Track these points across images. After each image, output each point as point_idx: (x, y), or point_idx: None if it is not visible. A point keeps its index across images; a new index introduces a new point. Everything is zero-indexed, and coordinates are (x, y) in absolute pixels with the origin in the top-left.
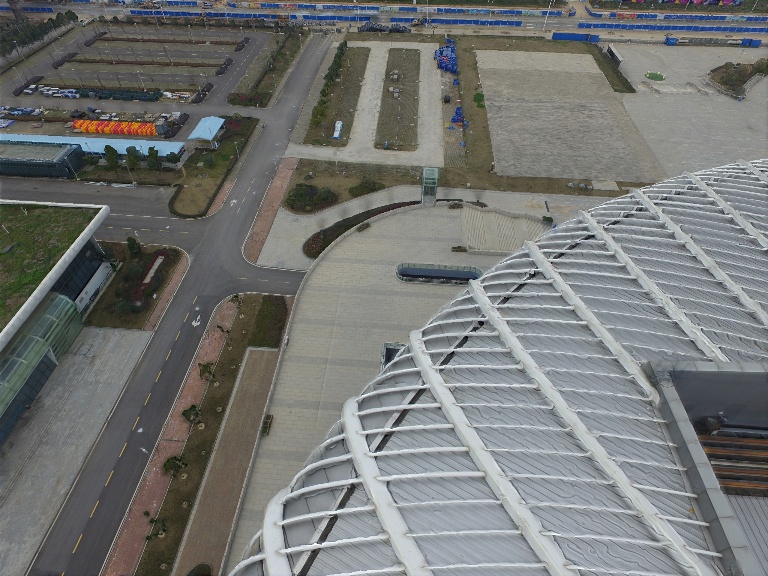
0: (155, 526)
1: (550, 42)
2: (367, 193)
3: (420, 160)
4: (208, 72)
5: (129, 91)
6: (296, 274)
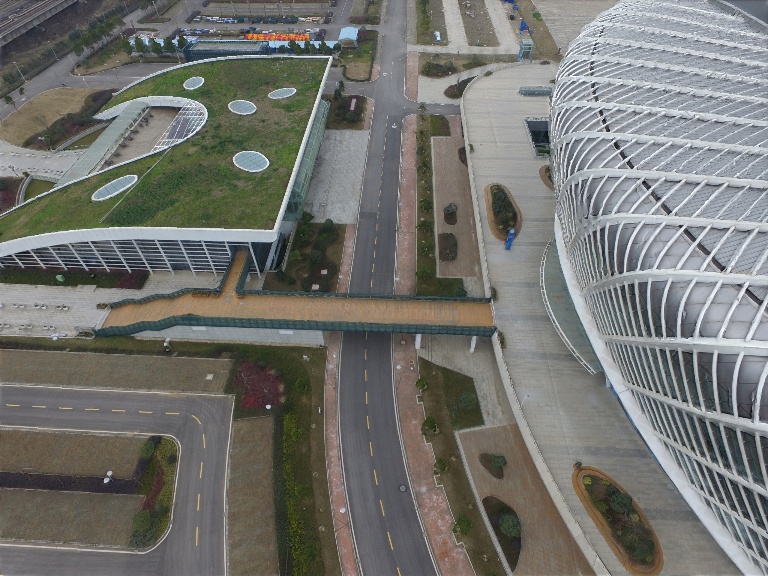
0: (417, 197)
1: None
2: (476, 67)
3: (505, 51)
4: (324, 6)
5: (273, 17)
6: (445, 106)
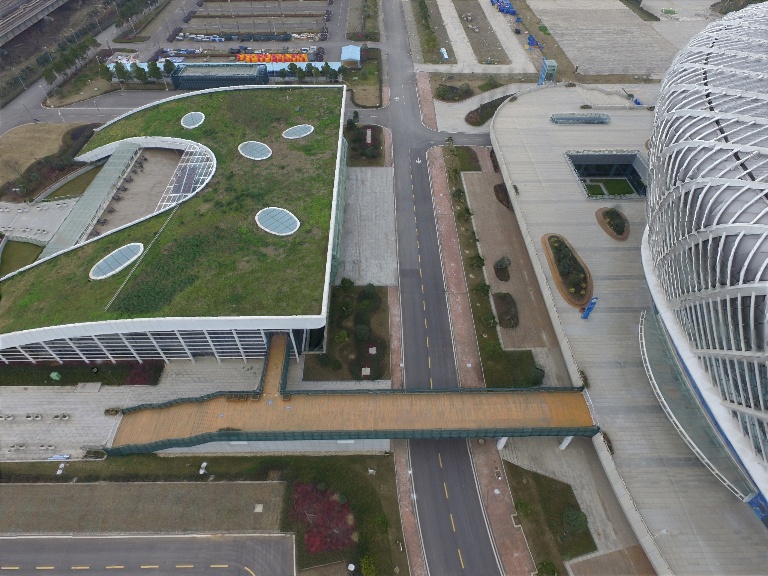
0: (461, 248)
1: None
2: (492, 89)
3: (518, 69)
4: None
5: (263, 35)
6: (469, 135)
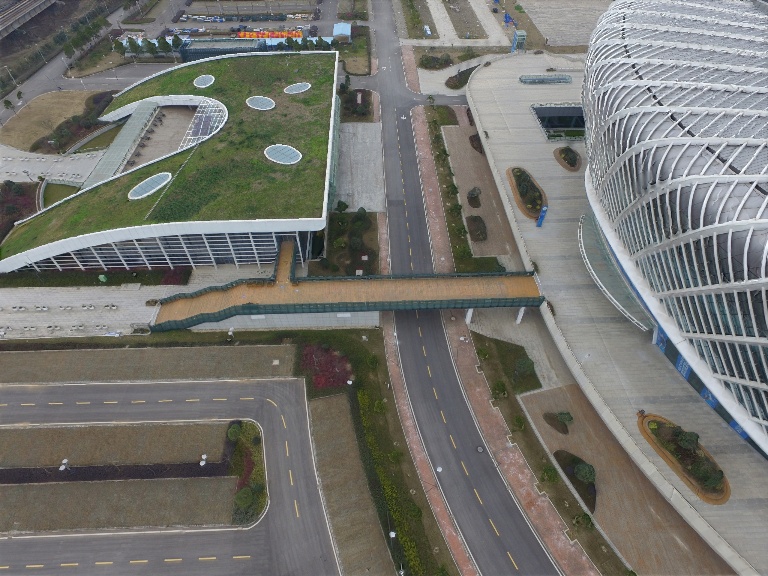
0: (440, 184)
1: None
2: (470, 59)
3: (494, 43)
4: None
5: (261, 15)
6: (448, 97)
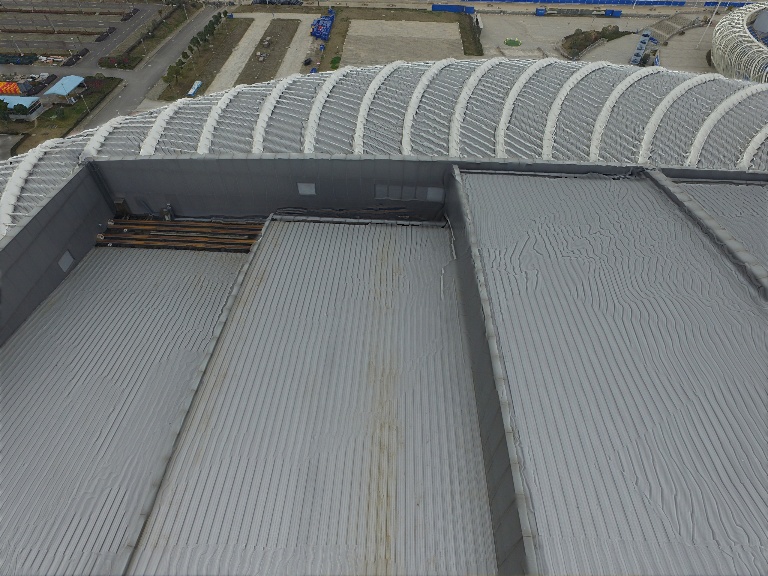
0: None
1: (425, 13)
2: None
3: None
4: (89, 39)
5: (6, 56)
6: None
